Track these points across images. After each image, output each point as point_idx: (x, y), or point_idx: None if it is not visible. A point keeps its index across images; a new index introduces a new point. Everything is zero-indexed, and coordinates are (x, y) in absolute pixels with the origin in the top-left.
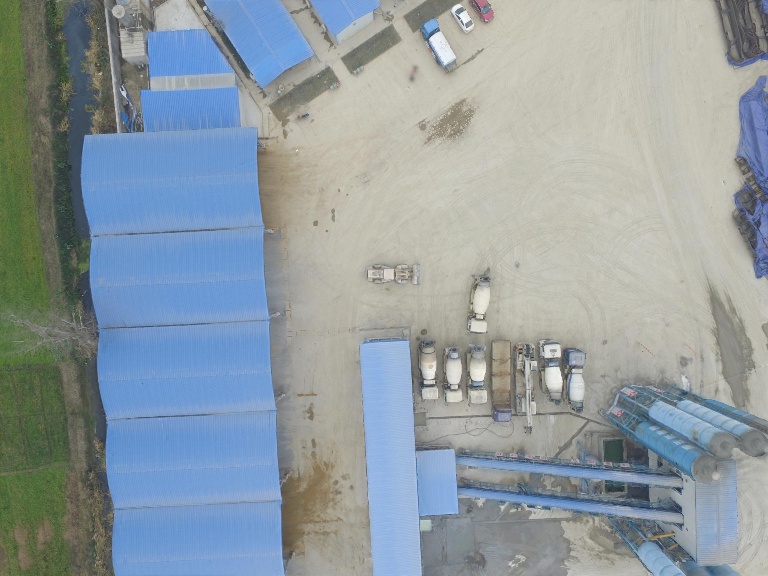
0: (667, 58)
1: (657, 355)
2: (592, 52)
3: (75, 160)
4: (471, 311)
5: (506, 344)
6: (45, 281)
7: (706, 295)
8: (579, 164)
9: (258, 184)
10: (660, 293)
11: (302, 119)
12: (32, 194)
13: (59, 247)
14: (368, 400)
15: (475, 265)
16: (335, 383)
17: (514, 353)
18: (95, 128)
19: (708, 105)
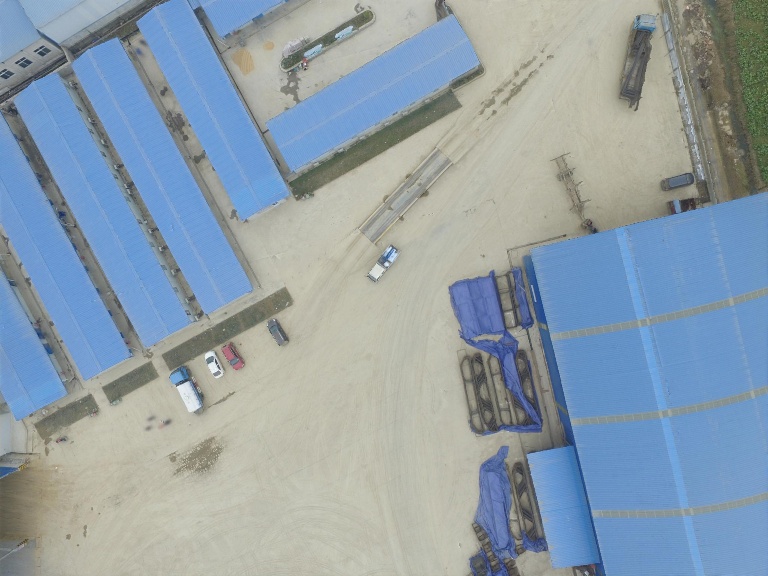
0: (410, 419)
1: None
2: (337, 406)
3: None
4: None
5: None
6: None
7: None
8: (318, 511)
9: None
10: None
11: (63, 440)
12: None
13: None
14: None
15: None
16: None
17: None
18: None
19: (448, 468)
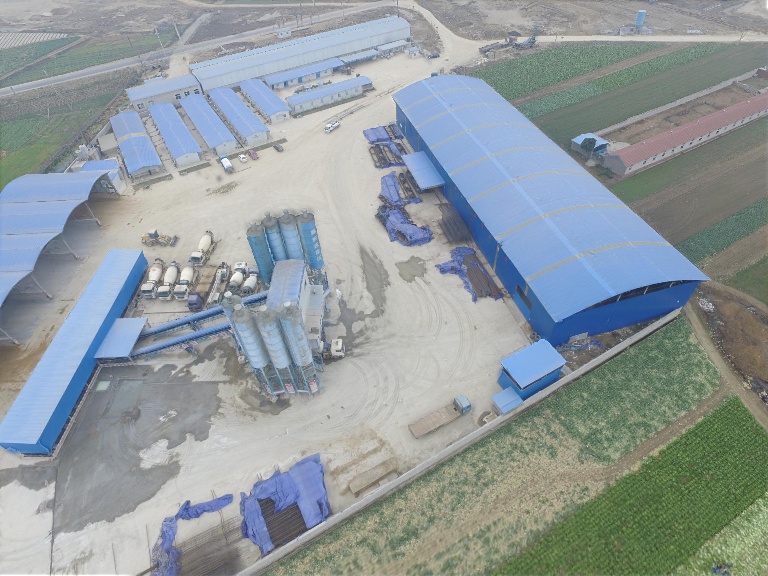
0: (344, 167)
1: None
2: (305, 167)
3: None
4: None
5: (214, 268)
6: None
7: (357, 250)
8: (288, 200)
9: None
10: (327, 249)
11: (146, 189)
12: None
13: None
14: (98, 275)
15: None
16: None
17: None
18: None
19: (364, 180)
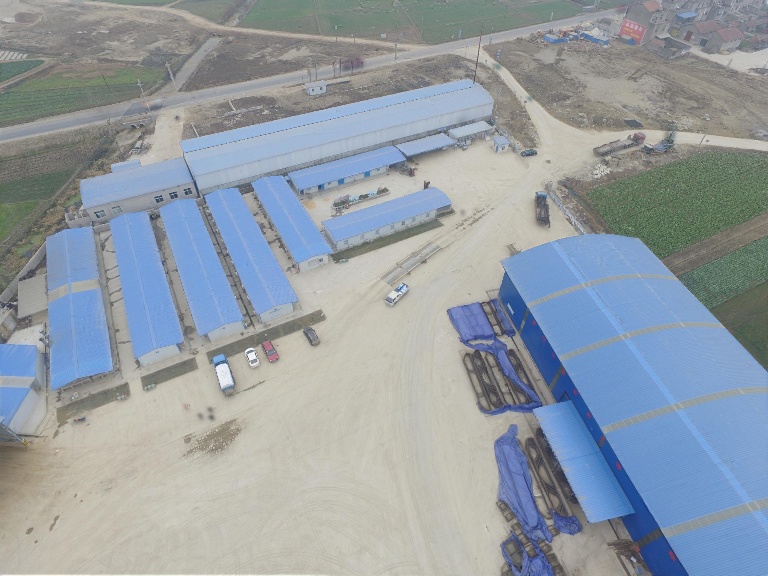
0: (424, 402)
1: None
2: (358, 392)
3: None
4: None
5: None
6: None
7: None
8: (332, 492)
9: None
10: None
11: (79, 422)
12: None
13: None
14: None
15: None
16: None
17: None
18: None
19: (464, 446)
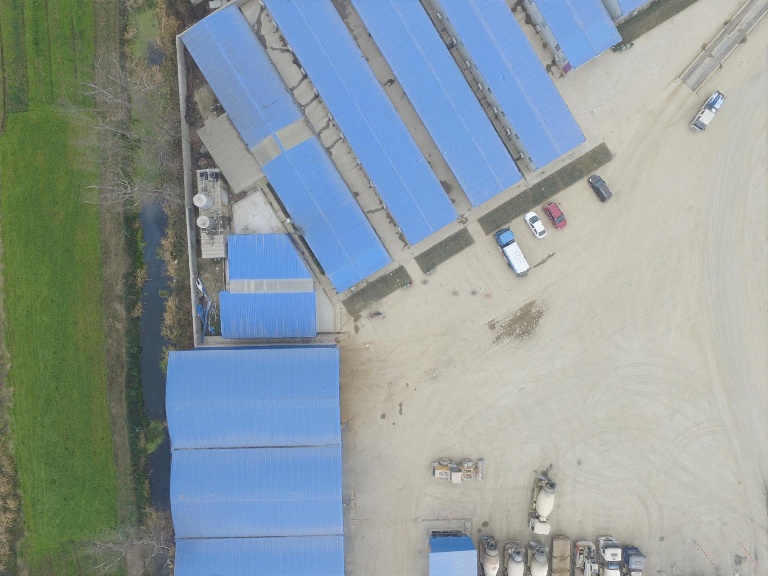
0: (733, 268)
1: (712, 553)
2: (660, 260)
3: (147, 343)
4: (533, 509)
5: (566, 542)
6: (113, 461)
7: (762, 496)
8: (643, 367)
9: (339, 409)
10: (717, 493)
11: (374, 316)
12: (103, 376)
13: (129, 430)
14: None
15: (538, 461)
16: (396, 571)
17: (573, 549)
18: (168, 314)
19: None
